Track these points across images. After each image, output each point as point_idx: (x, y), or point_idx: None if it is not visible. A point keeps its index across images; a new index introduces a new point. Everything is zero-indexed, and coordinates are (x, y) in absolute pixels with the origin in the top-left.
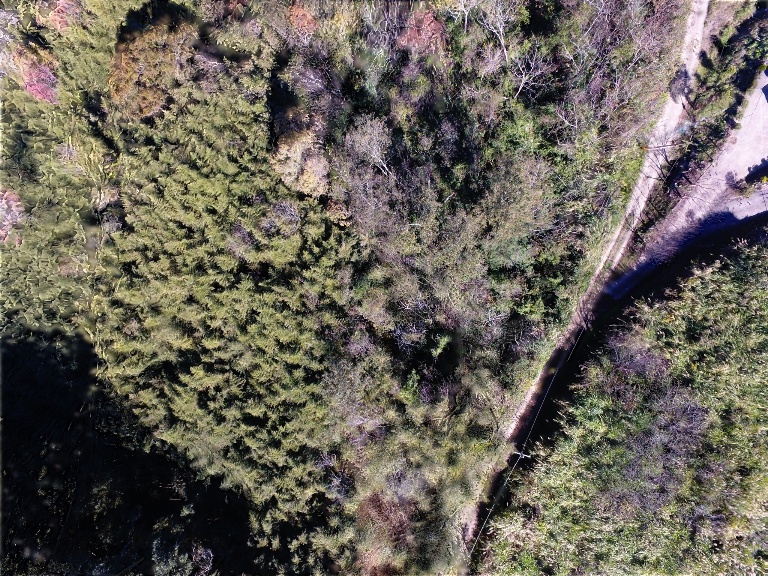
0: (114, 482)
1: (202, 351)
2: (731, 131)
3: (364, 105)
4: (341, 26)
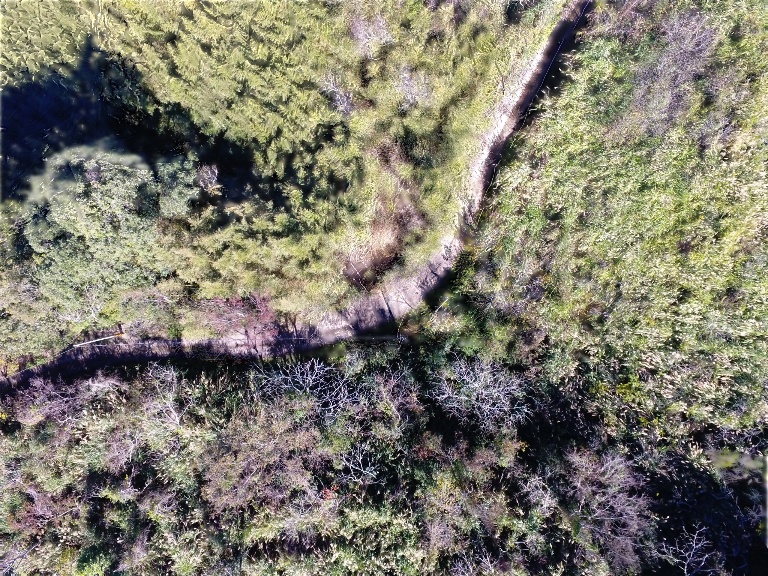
0: (118, 151)
1: (205, 3)
2: None
3: None
4: None
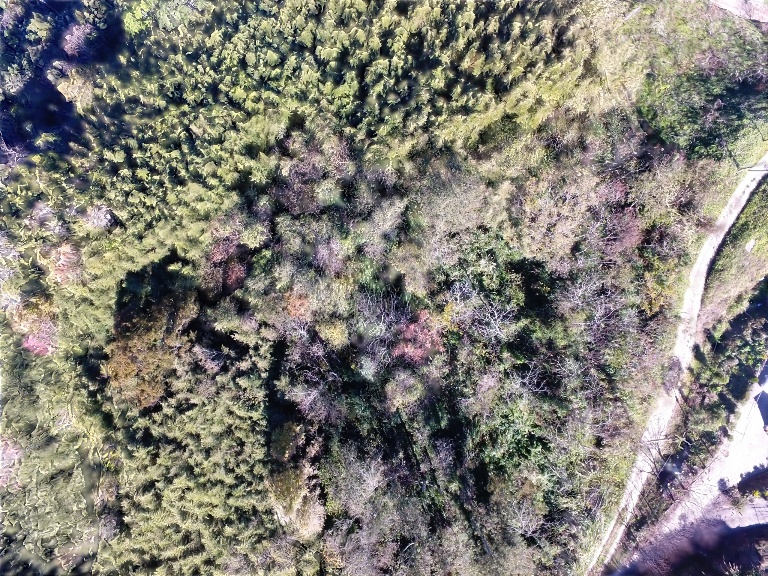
0: None
1: None
2: (723, 439)
3: (360, 380)
4: (338, 311)
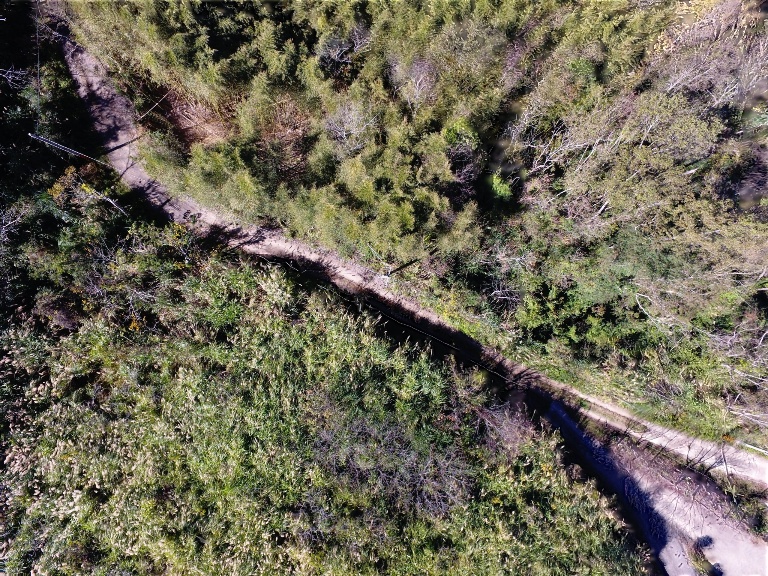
0: None
1: None
2: (761, 538)
3: None
4: None
